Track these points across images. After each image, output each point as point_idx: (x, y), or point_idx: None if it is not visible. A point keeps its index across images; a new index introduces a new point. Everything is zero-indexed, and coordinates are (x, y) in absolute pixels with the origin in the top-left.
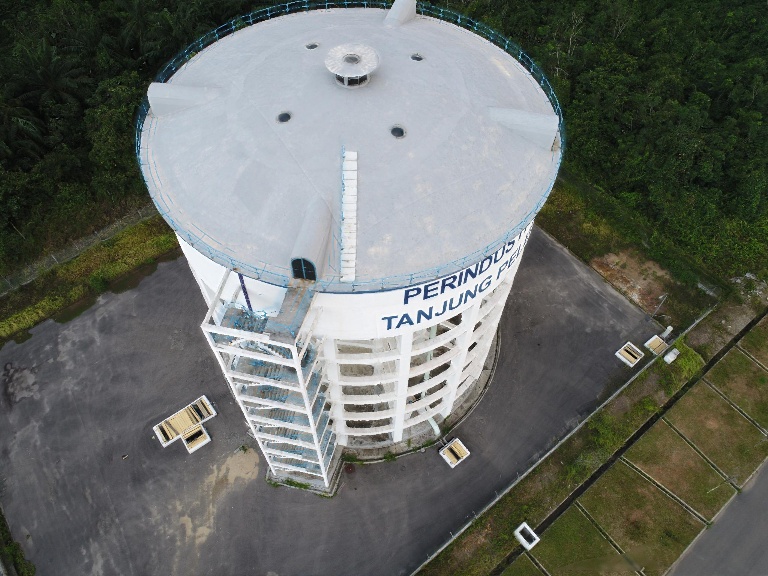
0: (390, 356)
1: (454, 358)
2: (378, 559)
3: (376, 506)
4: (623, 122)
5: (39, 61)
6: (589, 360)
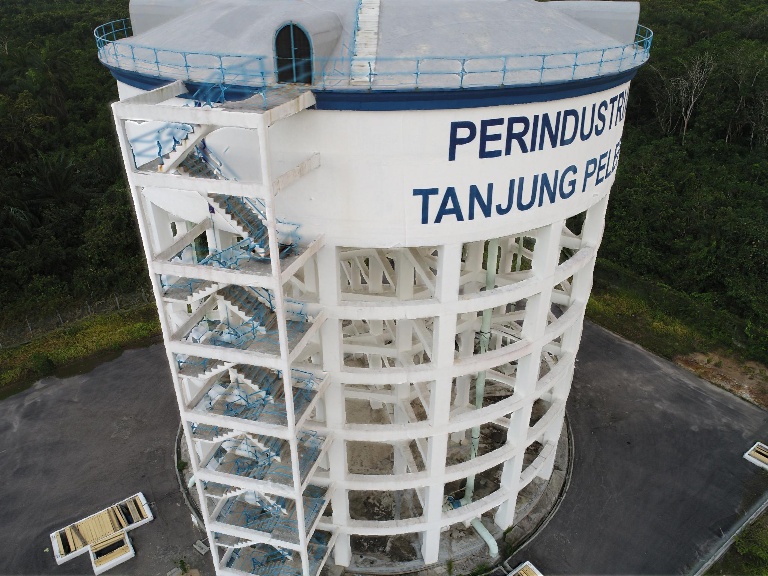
0: (424, 304)
1: (519, 374)
2: None
3: None
4: (674, 230)
5: (52, 168)
6: (708, 463)
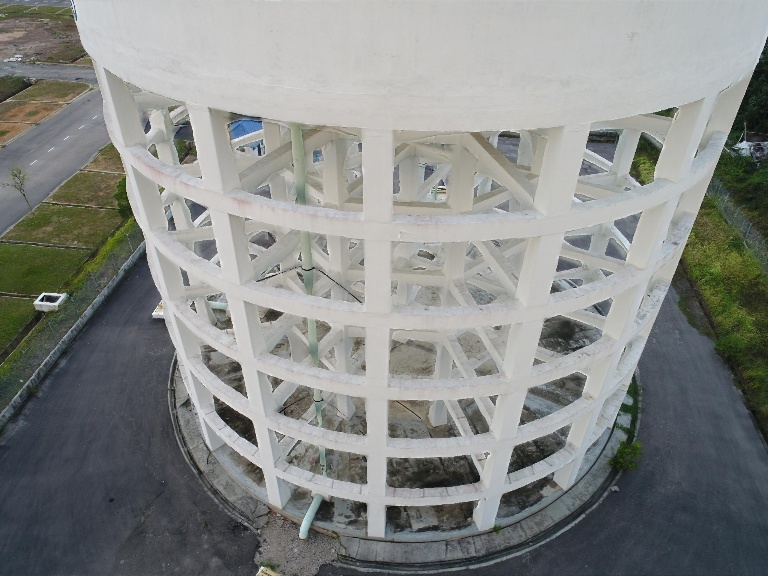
0: None
1: None
2: None
3: None
4: None
5: None
6: None
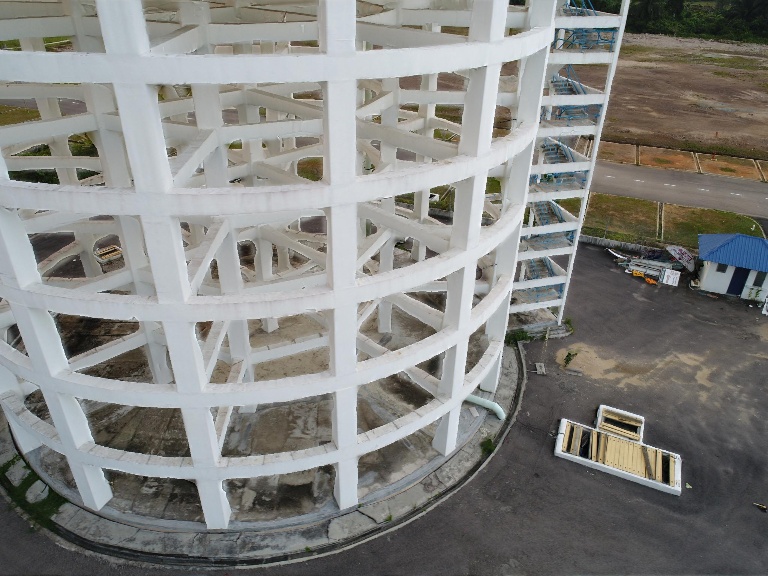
0: None
1: None
2: None
3: None
4: None
5: None
6: None
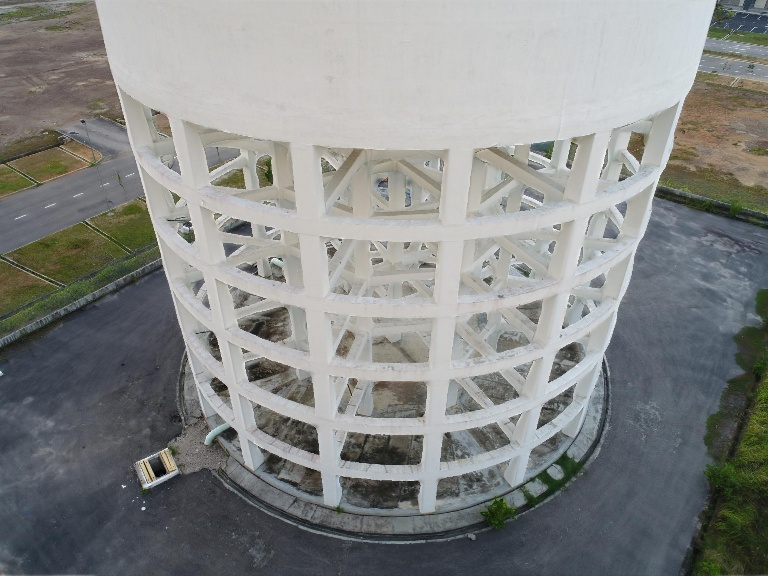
0: None
1: None
2: None
3: None
4: None
5: None
6: (51, 360)
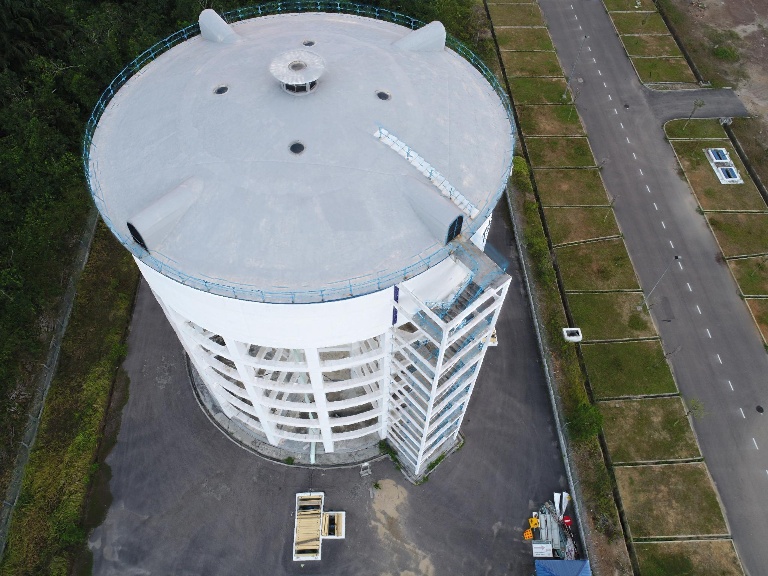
0: None
1: None
2: (531, 439)
3: (491, 415)
4: None
5: None
6: None
